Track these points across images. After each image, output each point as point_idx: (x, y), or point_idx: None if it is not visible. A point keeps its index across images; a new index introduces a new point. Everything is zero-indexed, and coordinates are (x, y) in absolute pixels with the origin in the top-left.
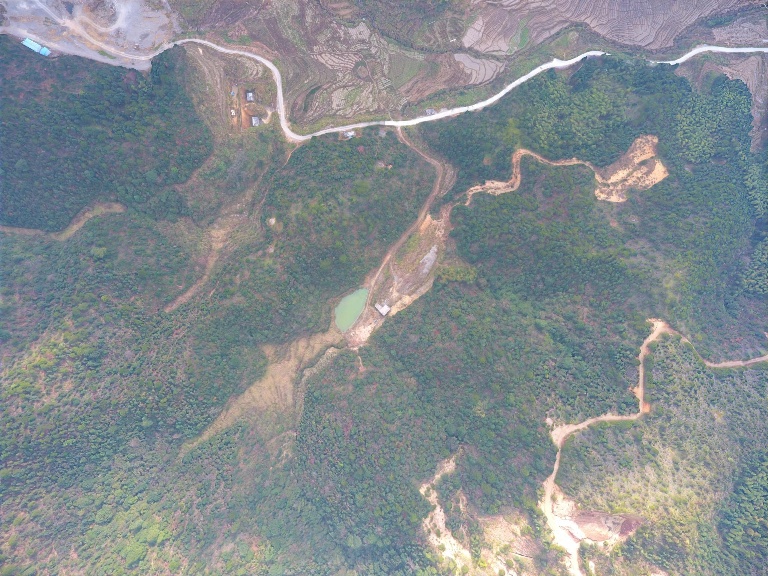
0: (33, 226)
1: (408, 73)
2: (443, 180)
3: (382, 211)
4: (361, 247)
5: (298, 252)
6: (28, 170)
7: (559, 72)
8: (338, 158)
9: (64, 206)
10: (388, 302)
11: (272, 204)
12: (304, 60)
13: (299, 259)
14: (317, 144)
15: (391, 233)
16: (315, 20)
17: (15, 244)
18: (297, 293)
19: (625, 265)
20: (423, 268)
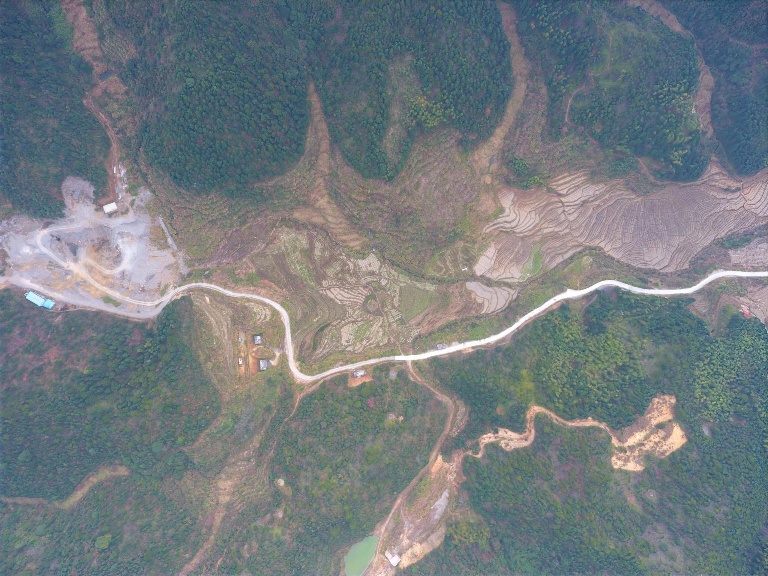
0: (36, 496)
1: (419, 306)
2: (454, 417)
3: (393, 470)
4: (371, 506)
5: (307, 522)
6: (31, 458)
7: (573, 303)
8: (348, 415)
9: (68, 479)
10: (398, 549)
11: (281, 465)
12: (313, 298)
13: (308, 528)
14: (326, 396)
15: (402, 485)
16: (324, 253)
17: (18, 524)
18: (306, 556)
19: (644, 567)
20: (434, 514)
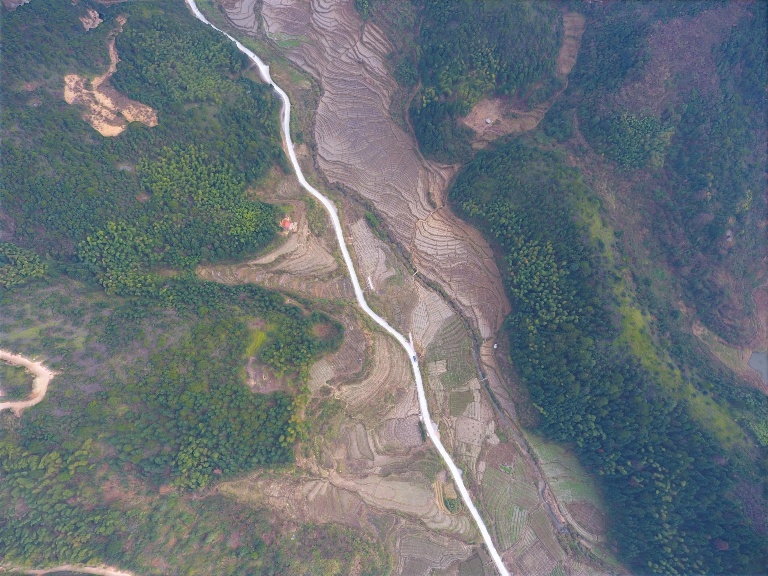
0: None
1: None
2: None
3: None
4: None
5: None
6: None
7: (256, 74)
8: None
9: None
10: None
11: None
12: None
13: None
14: None
15: None
16: None
17: None
18: None
19: None
20: (16, 3)
